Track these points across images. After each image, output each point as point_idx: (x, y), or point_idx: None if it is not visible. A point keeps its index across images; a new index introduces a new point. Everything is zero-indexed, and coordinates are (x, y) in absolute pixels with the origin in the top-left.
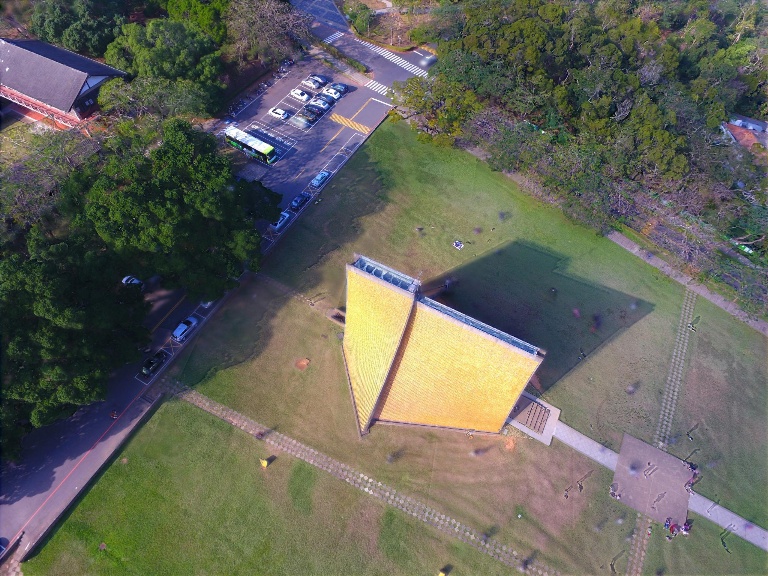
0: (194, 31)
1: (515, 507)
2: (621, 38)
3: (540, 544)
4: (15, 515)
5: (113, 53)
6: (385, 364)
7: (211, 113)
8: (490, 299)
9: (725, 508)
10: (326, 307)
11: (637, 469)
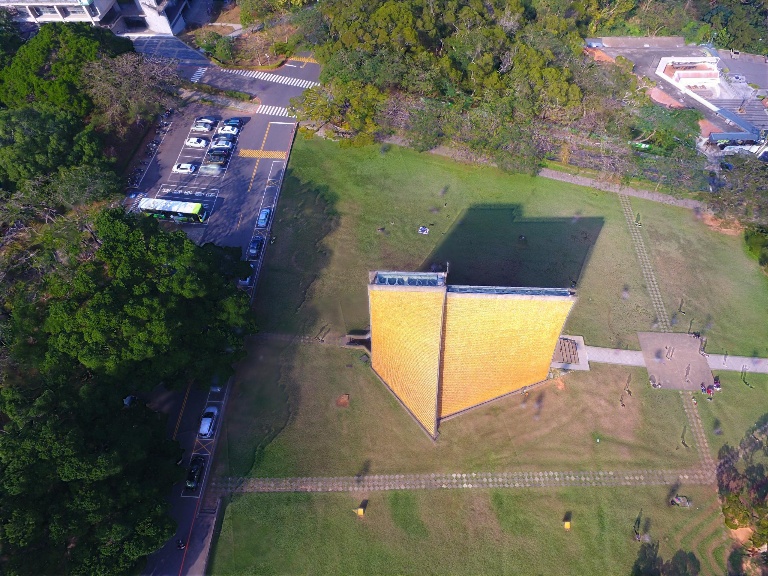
0: (51, 112)
1: (591, 435)
2: None
3: (625, 455)
4: None
5: None
6: (432, 364)
7: (114, 192)
8: (476, 267)
9: (733, 356)
10: (336, 338)
11: (660, 356)
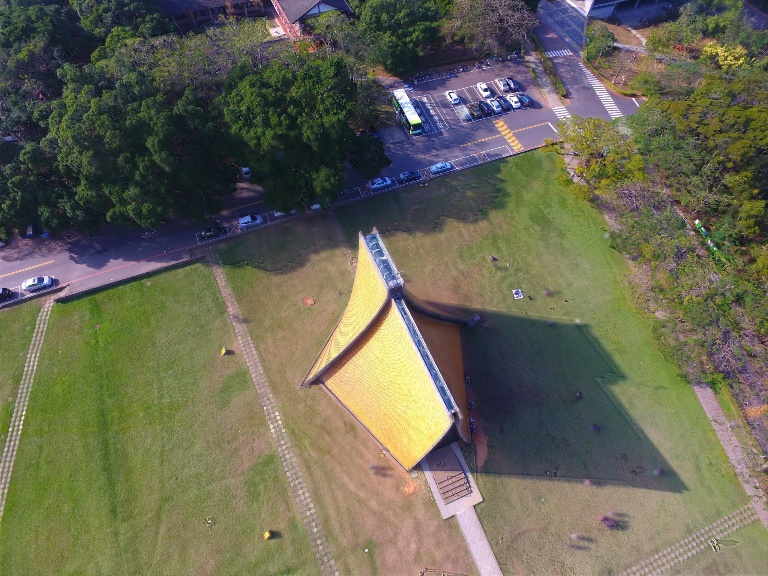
0: None
1: (369, 540)
2: None
3: None
4: (73, 271)
5: None
6: (349, 339)
7: (395, 71)
8: (505, 359)
9: None
10: None
11: None
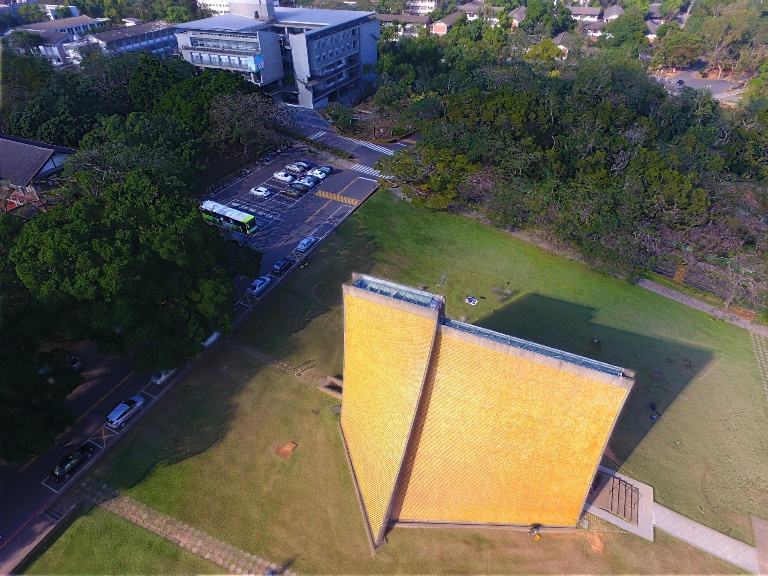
0: (176, 122)
1: None
2: None
3: None
4: None
5: (88, 139)
6: (403, 428)
7: (187, 190)
8: None
9: None
10: (316, 376)
11: None
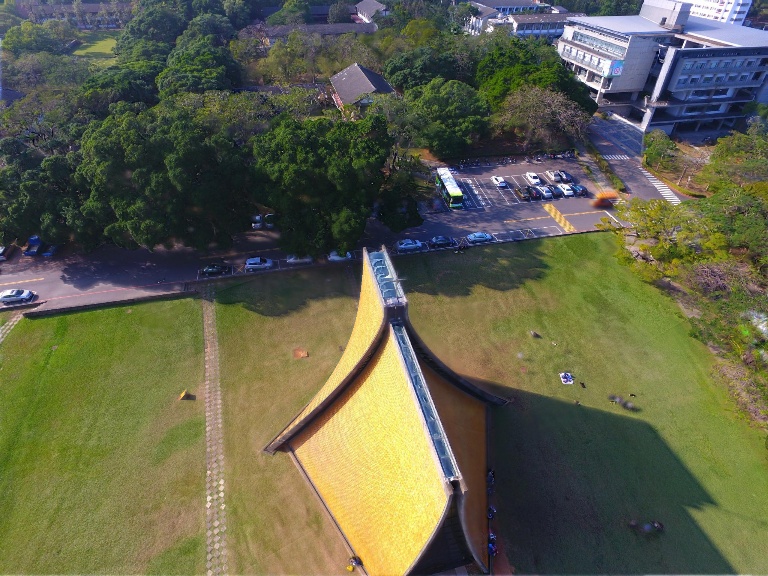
0: (481, 99)
1: None
2: None
3: None
4: (57, 290)
5: (410, 90)
6: (332, 387)
7: (441, 153)
8: (546, 457)
9: None
10: None
11: None
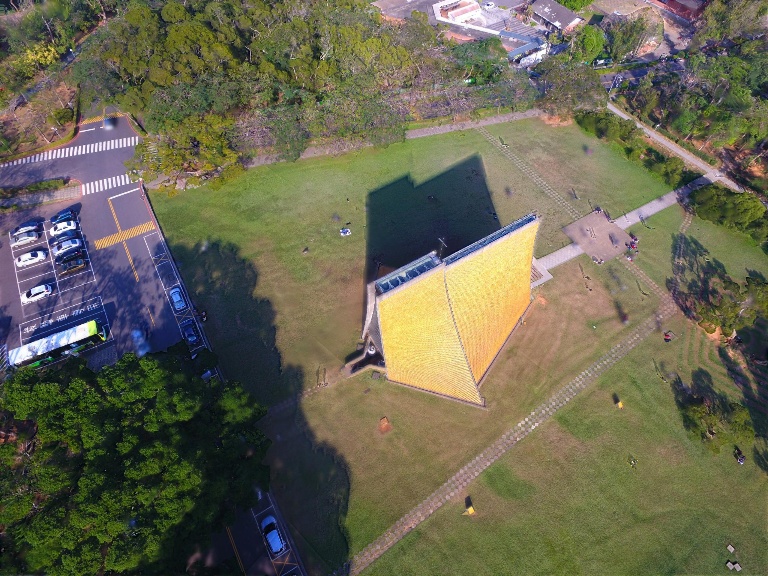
0: None
1: (587, 326)
2: (242, 2)
3: (617, 326)
4: None
5: None
6: (453, 341)
7: None
8: (413, 241)
9: (629, 212)
10: (337, 373)
11: (588, 239)
